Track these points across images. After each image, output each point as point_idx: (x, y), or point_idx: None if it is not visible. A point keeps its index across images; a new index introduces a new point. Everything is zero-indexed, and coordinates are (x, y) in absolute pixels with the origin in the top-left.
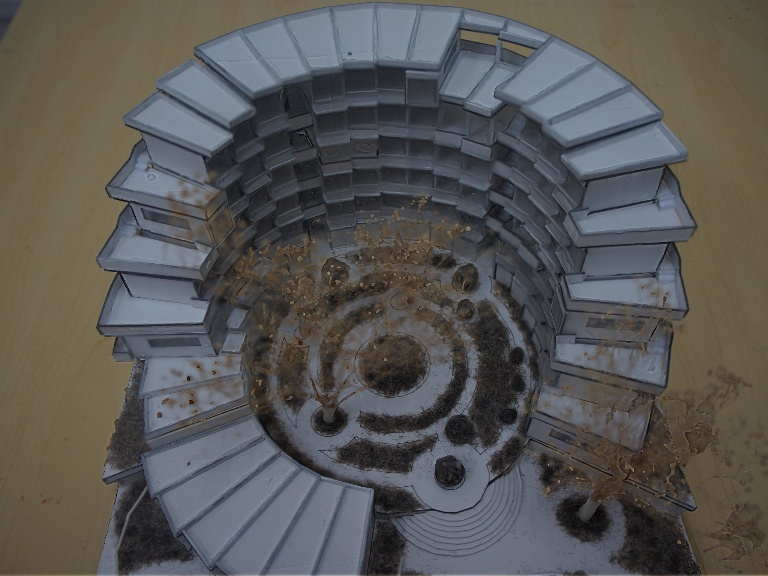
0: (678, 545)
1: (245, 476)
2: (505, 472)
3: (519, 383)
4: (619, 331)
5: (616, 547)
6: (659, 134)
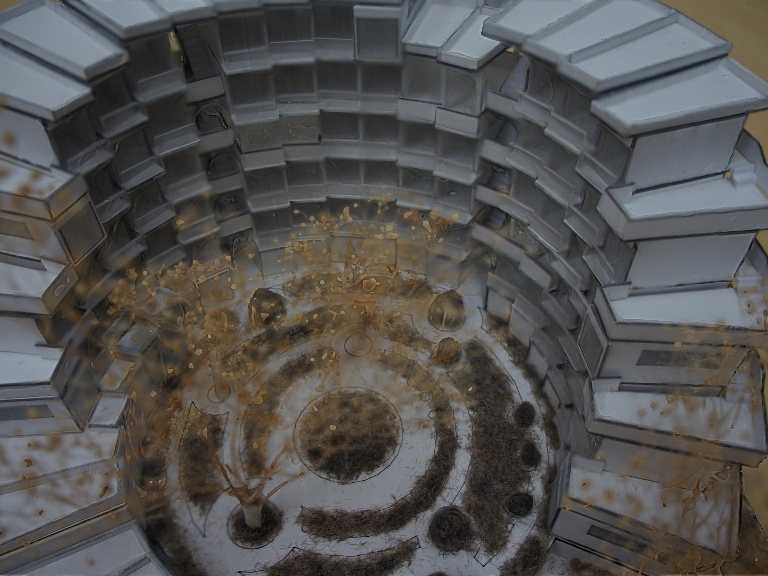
0: None
1: None
2: None
3: (532, 454)
4: (685, 370)
5: None
6: (728, 75)
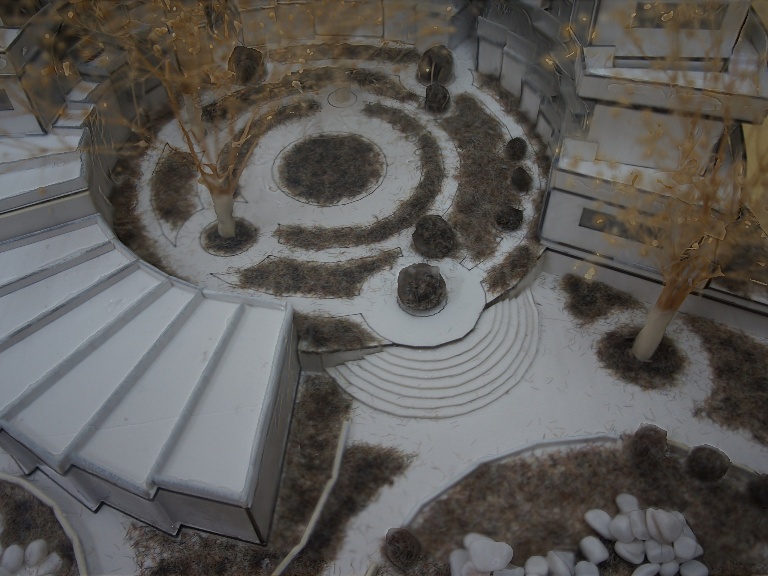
0: None
1: (73, 294)
2: (510, 293)
3: (523, 174)
4: (685, 33)
5: (700, 394)
6: None
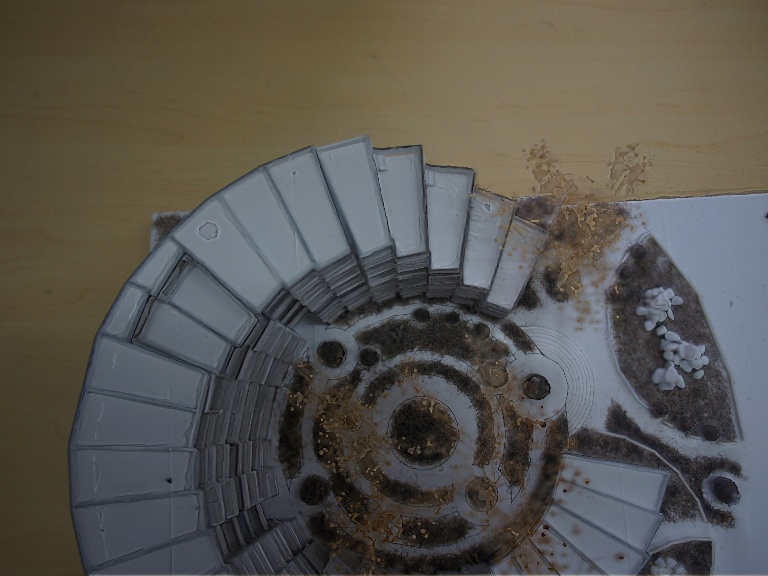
0: (584, 214)
1: (552, 571)
2: None
3: (455, 317)
4: None
5: None
6: (329, 155)
